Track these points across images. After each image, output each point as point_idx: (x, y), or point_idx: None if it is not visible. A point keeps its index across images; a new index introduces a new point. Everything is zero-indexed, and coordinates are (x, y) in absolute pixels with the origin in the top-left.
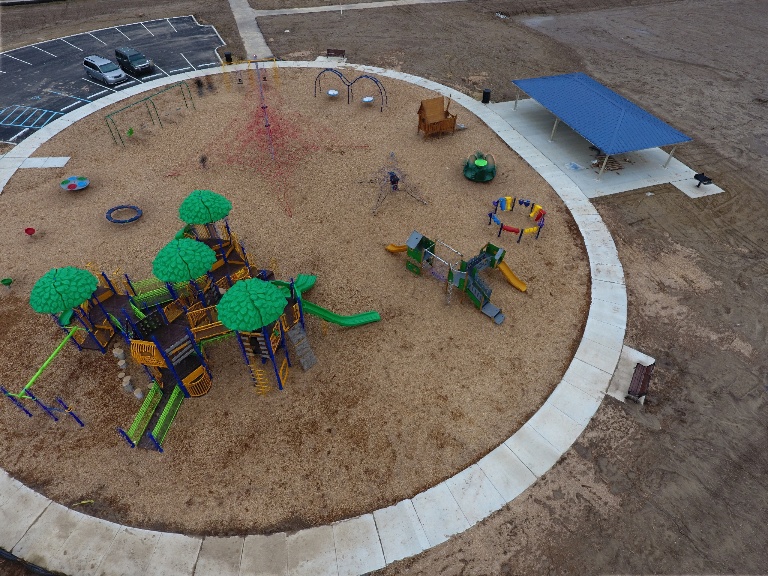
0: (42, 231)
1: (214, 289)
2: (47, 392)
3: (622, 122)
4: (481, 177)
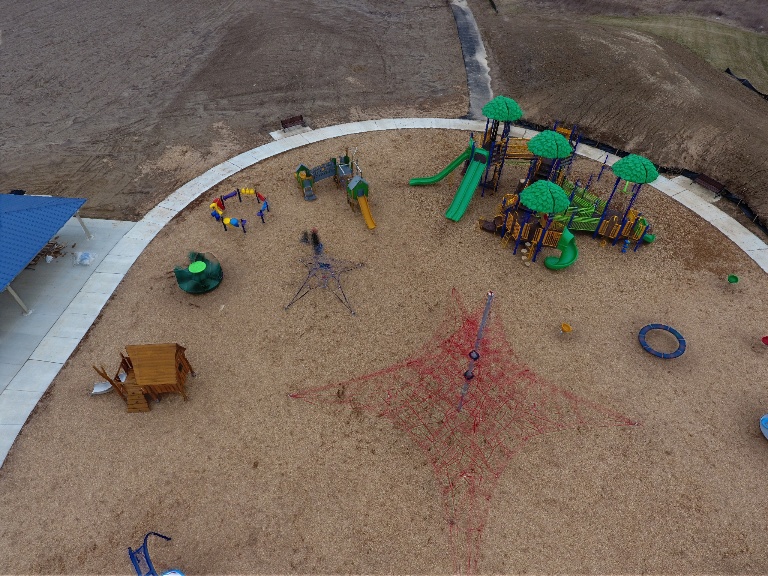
0: (761, 355)
1: None
2: None
3: (6, 210)
4: None
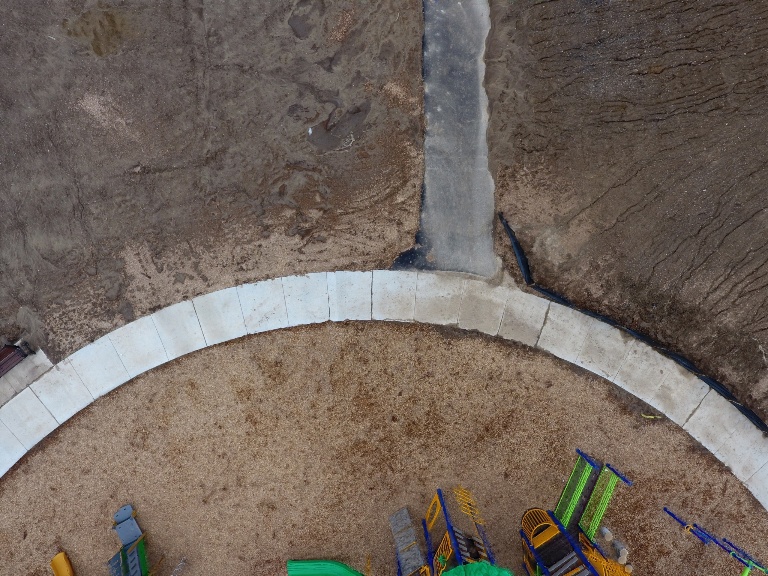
0: None
1: None
2: (712, 569)
3: None
4: None
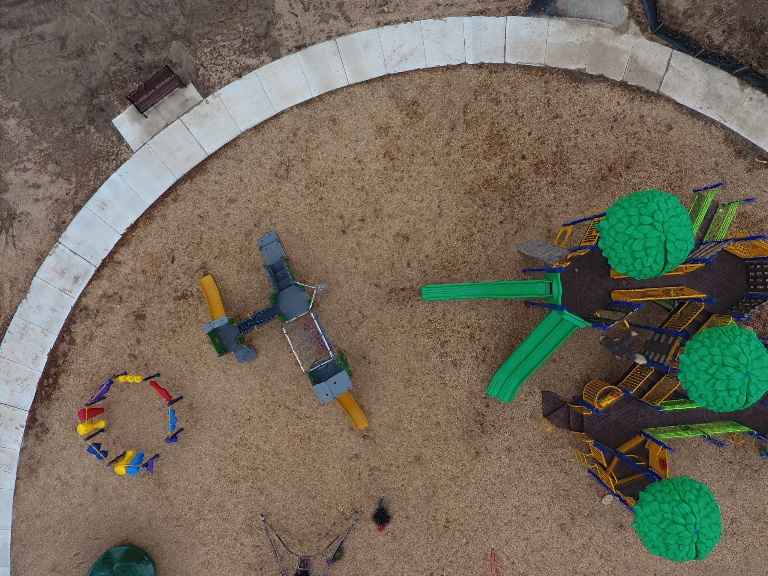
0: None
1: (656, 359)
2: None
3: None
4: (132, 555)
